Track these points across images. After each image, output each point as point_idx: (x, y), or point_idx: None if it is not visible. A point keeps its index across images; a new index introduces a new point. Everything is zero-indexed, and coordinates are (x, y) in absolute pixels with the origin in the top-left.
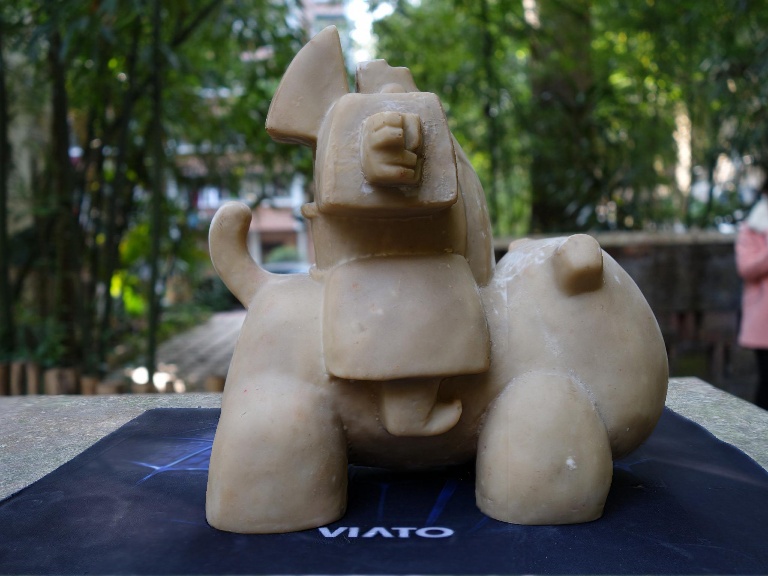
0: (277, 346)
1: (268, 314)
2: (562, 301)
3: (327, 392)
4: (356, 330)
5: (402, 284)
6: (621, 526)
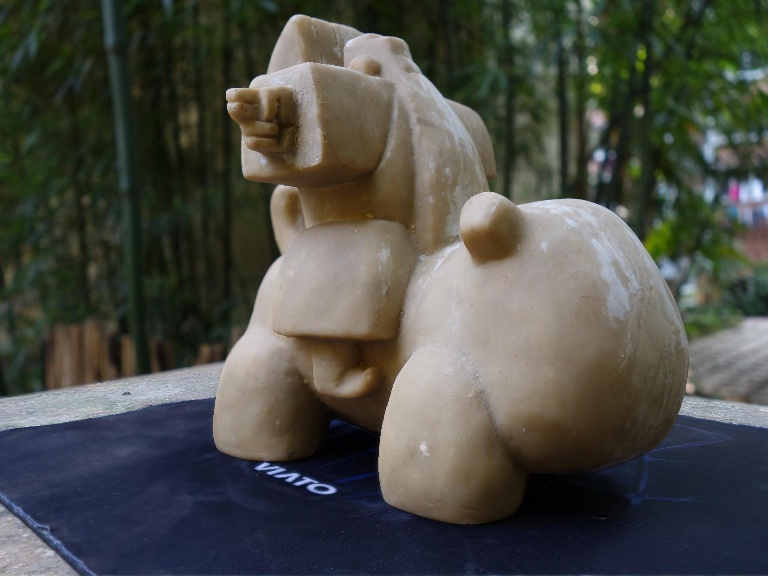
0: (262, 302)
1: None
2: (472, 271)
3: (286, 346)
4: (278, 289)
5: (311, 248)
6: (473, 537)
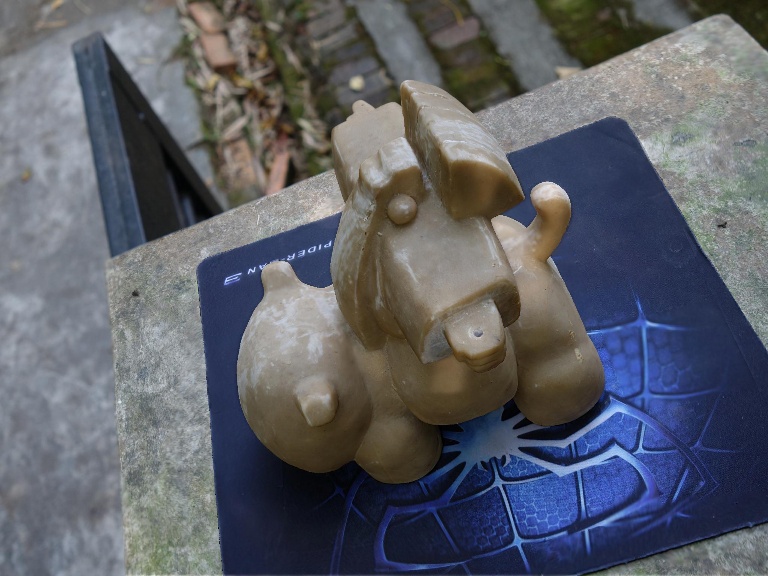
0: None
1: None
2: None
3: None
4: None
5: None
6: None
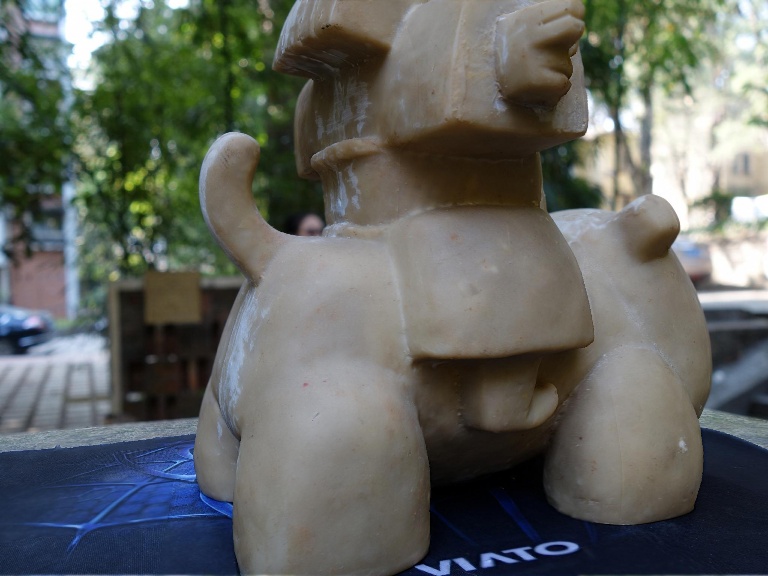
0: (343, 321)
1: (323, 279)
2: (635, 268)
3: (409, 381)
4: (467, 293)
5: (512, 236)
6: (723, 511)
